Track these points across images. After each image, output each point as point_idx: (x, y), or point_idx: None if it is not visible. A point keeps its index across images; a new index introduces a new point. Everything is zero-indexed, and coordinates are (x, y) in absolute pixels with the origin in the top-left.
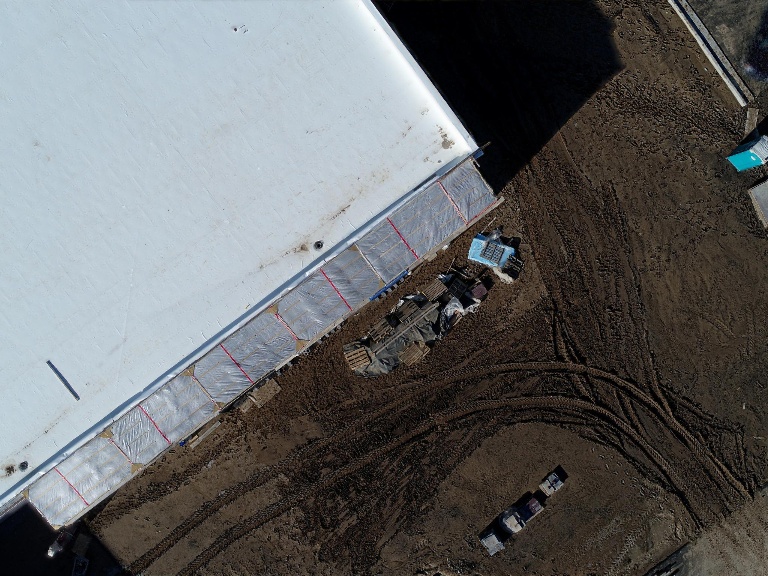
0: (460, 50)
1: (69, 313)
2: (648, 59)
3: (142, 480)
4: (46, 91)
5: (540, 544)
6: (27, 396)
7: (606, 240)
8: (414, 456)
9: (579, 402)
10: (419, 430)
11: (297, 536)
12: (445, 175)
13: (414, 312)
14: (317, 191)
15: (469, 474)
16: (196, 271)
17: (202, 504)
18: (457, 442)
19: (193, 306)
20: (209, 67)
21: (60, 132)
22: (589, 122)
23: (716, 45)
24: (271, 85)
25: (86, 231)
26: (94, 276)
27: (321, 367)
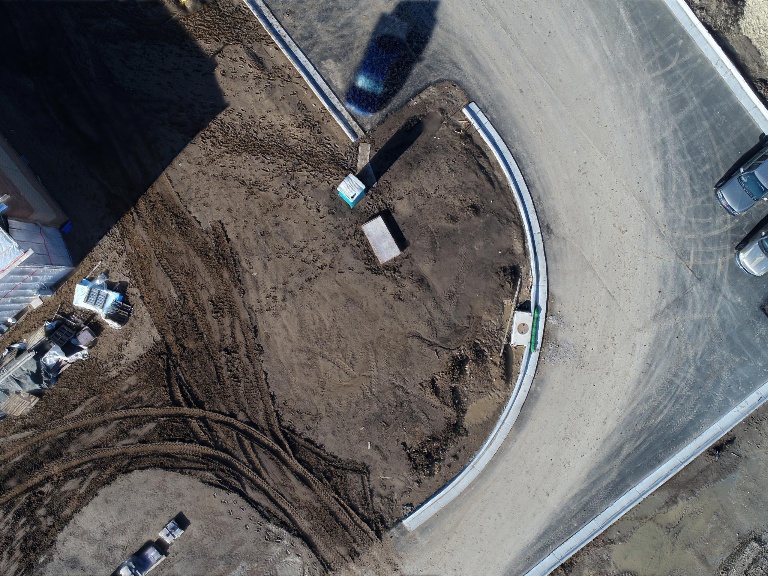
0: (56, 93)
1: None
2: (252, 96)
3: None
4: None
5: None
6: None
7: (218, 281)
8: (29, 507)
9: (199, 447)
10: (34, 481)
11: None
12: None
13: (9, 362)
14: None
15: (88, 524)
16: None
17: None
18: (74, 492)
19: None
20: None
21: None
22: (194, 162)
23: (322, 80)
24: None
25: None
26: None
27: None
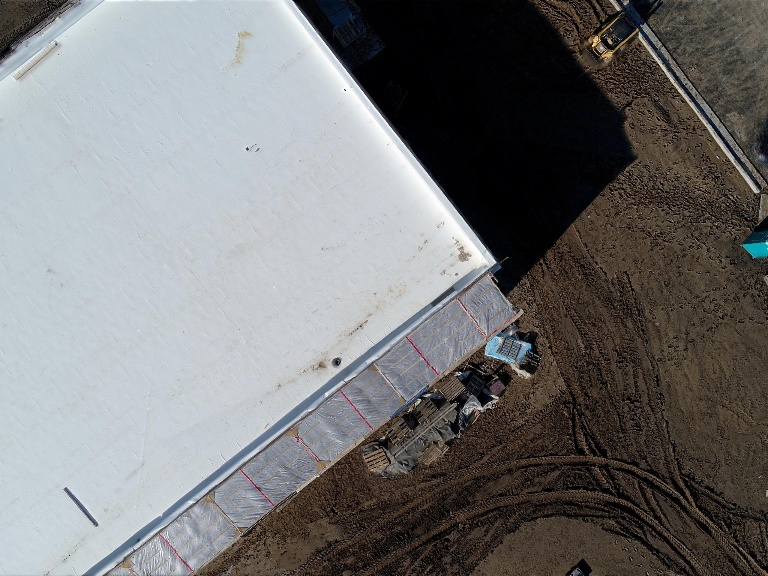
0: (471, 146)
1: (85, 439)
2: (660, 149)
3: None
4: (57, 216)
5: None
6: (45, 524)
7: (623, 331)
8: (436, 555)
9: (601, 495)
10: (440, 528)
11: None
12: (463, 292)
13: (432, 413)
14: (334, 308)
15: (492, 571)
16: (213, 392)
17: None
18: (479, 539)
19: (211, 427)
20: (221, 187)
21: (72, 257)
22: (602, 214)
23: (727, 133)
24: (284, 203)
25: (101, 356)
26: (110, 401)
27: (339, 469)
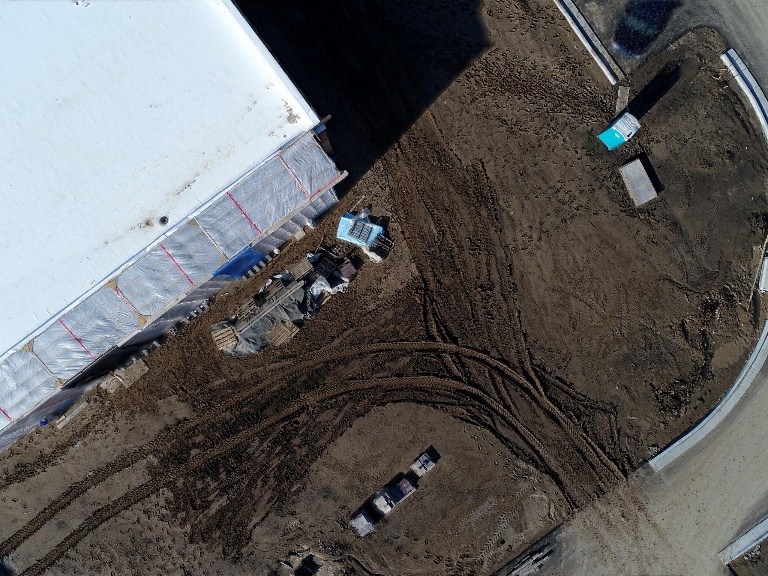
0: (327, 28)
1: None
2: (517, 37)
3: (9, 461)
4: None
5: (413, 525)
6: None
7: (477, 219)
8: (285, 437)
9: (451, 382)
10: (290, 410)
11: (167, 517)
12: (285, 149)
13: (279, 291)
14: (162, 166)
15: (340, 455)
16: (40, 247)
17: (70, 485)
18: (328, 422)
19: (37, 282)
20: (51, 41)
21: None
22: (458, 100)
23: (586, 23)
24: (114, 59)
25: None
26: None
27: (189, 347)
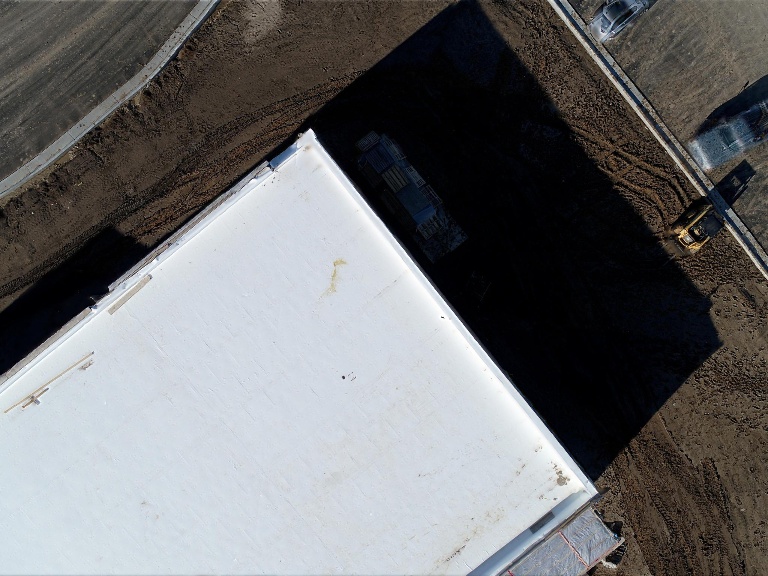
0: (555, 336)
1: None
2: (745, 335)
3: None
4: (152, 449)
5: None
6: None
7: (709, 518)
8: None
9: None
10: None
11: None
12: (566, 525)
13: None
14: (431, 533)
15: None
16: None
17: None
18: None
19: None
20: (318, 416)
21: (168, 489)
22: (688, 402)
23: None
24: (381, 431)
25: None
26: None
27: None
